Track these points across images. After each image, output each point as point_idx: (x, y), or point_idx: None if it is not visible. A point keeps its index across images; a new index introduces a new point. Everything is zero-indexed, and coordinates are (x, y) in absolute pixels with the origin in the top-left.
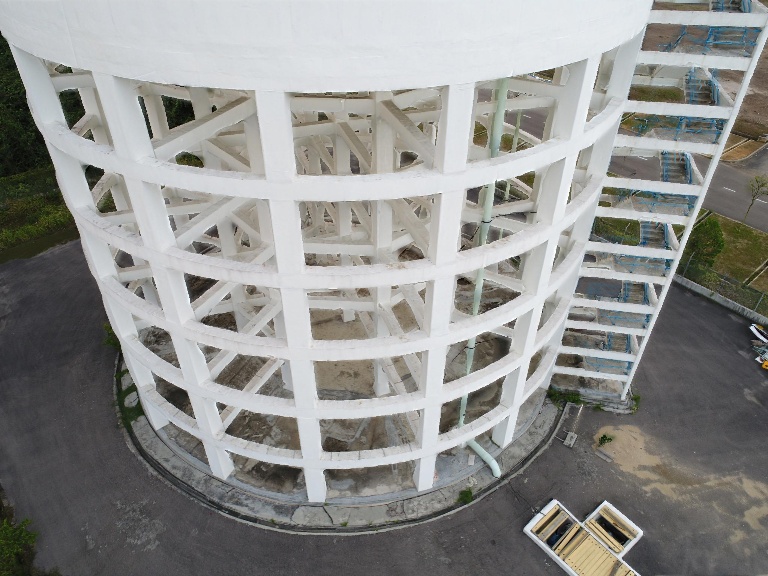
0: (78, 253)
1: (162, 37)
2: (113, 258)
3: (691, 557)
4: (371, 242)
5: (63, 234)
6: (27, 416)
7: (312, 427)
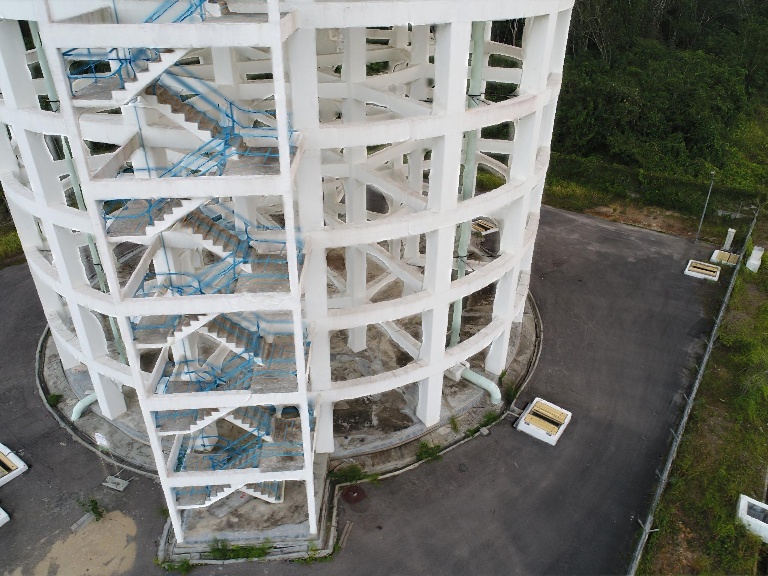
0: None
1: None
2: None
3: None
4: None
5: None
6: None
7: None
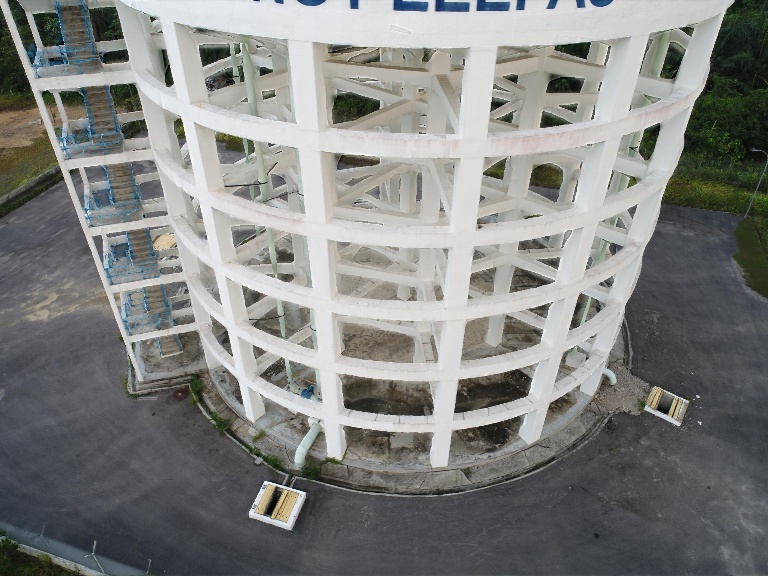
0: (713, 274)
1: None
2: None
3: None
4: None
5: (766, 282)
6: None
7: None
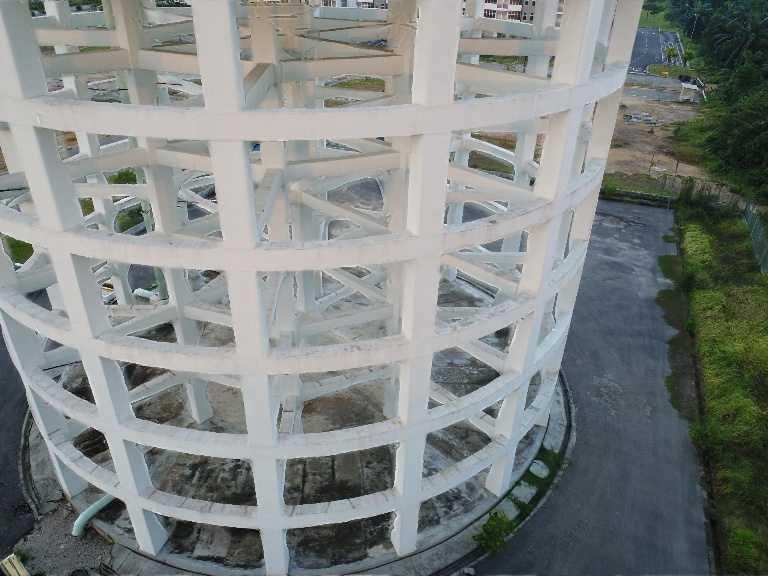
0: None
1: None
2: None
3: None
4: None
5: None
6: (649, 570)
7: None
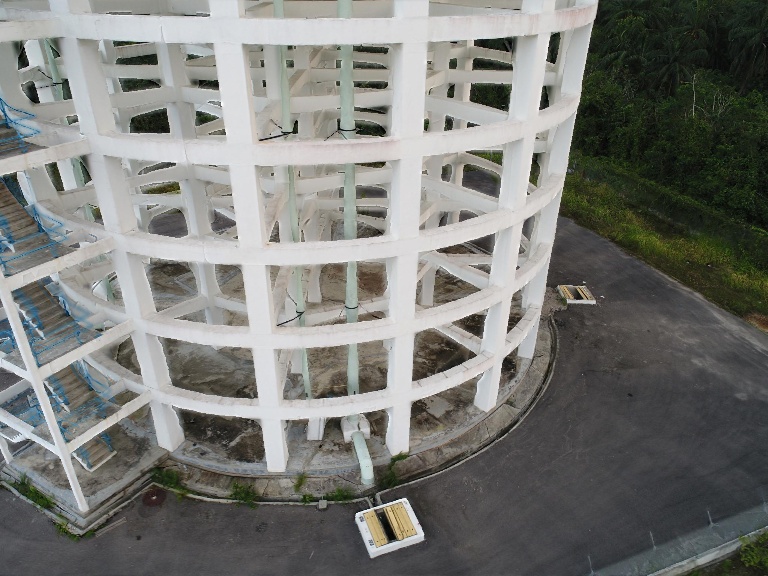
0: None
1: None
2: (333, 126)
3: None
4: None
5: None
6: None
7: None
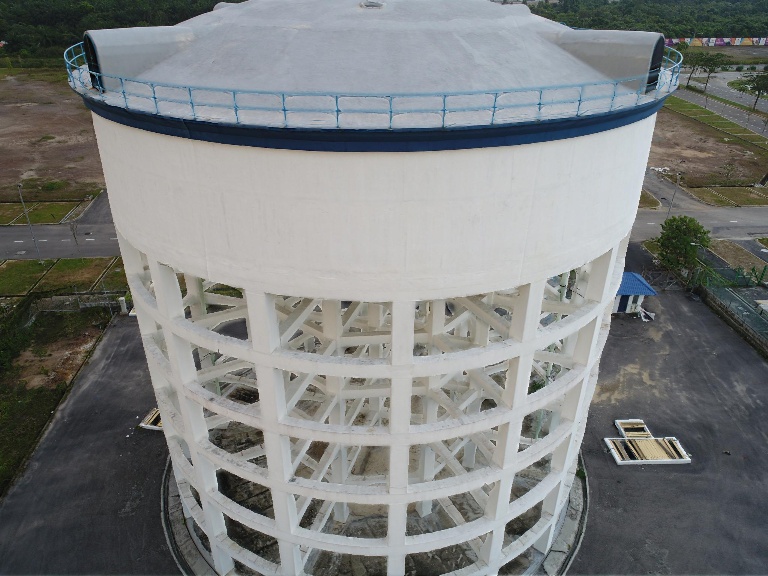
0: None
1: (587, 236)
2: None
3: (661, 415)
4: (478, 345)
5: None
6: None
7: (564, 481)
